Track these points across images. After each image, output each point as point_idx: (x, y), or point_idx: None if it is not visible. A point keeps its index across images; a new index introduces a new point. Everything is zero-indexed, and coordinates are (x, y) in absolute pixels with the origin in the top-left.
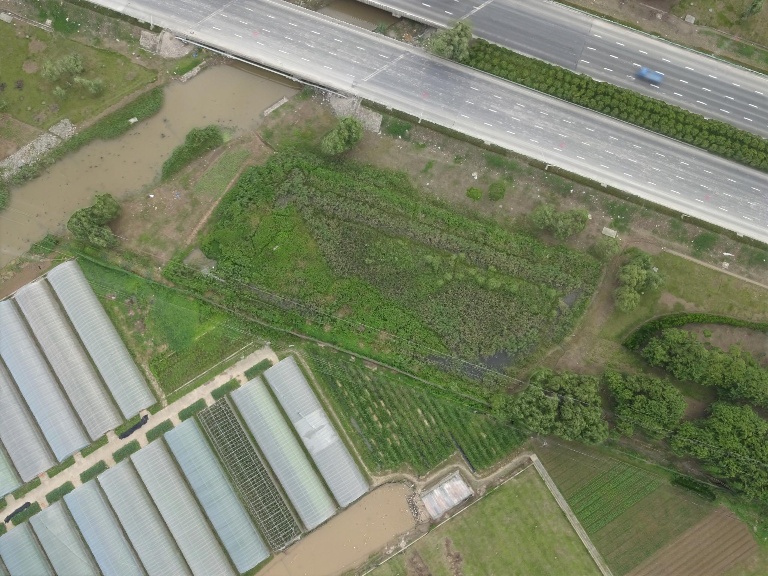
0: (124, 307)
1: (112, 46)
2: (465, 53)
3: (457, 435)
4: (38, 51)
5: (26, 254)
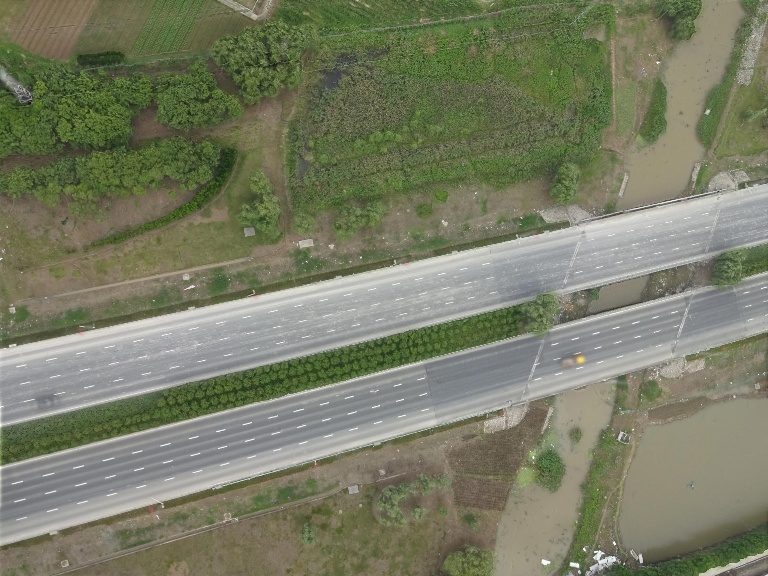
0: None
1: (759, 158)
2: (525, 307)
3: (327, 2)
4: None
5: None
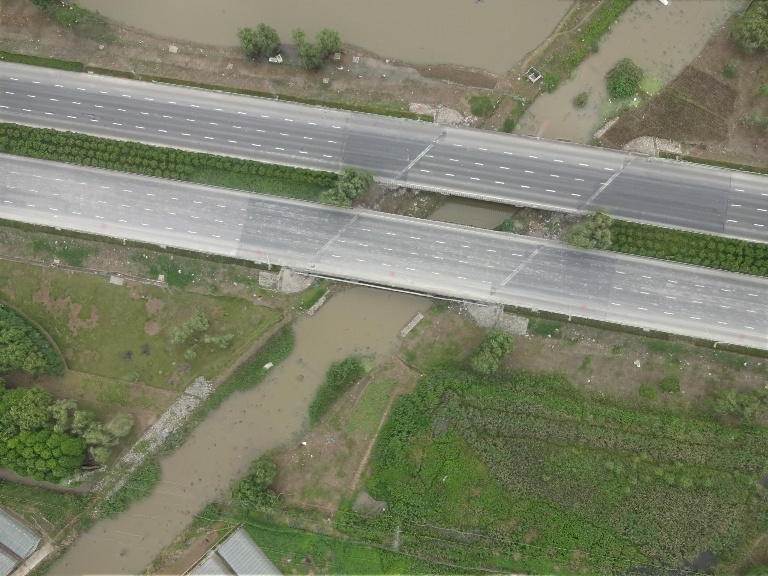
0: (302, 568)
1: (231, 291)
2: (609, 243)
3: None
4: (157, 310)
5: (190, 528)
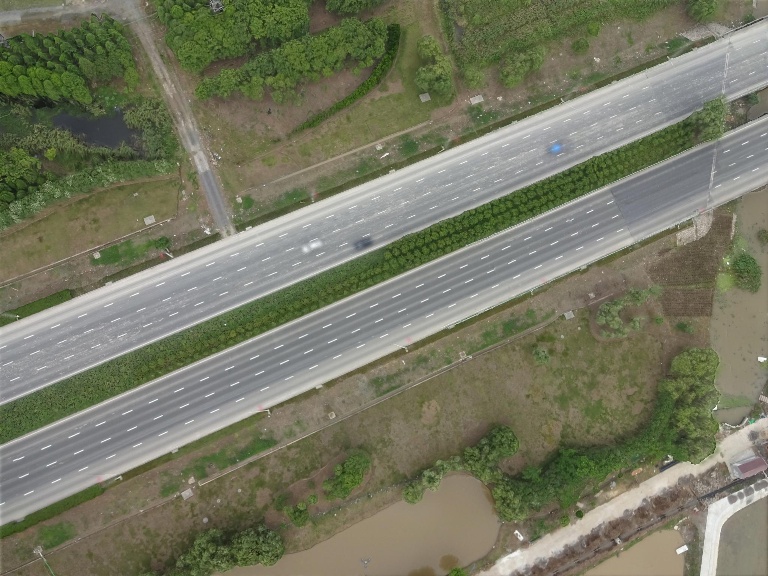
0: None
1: None
2: (695, 116)
3: None
4: None
5: None
